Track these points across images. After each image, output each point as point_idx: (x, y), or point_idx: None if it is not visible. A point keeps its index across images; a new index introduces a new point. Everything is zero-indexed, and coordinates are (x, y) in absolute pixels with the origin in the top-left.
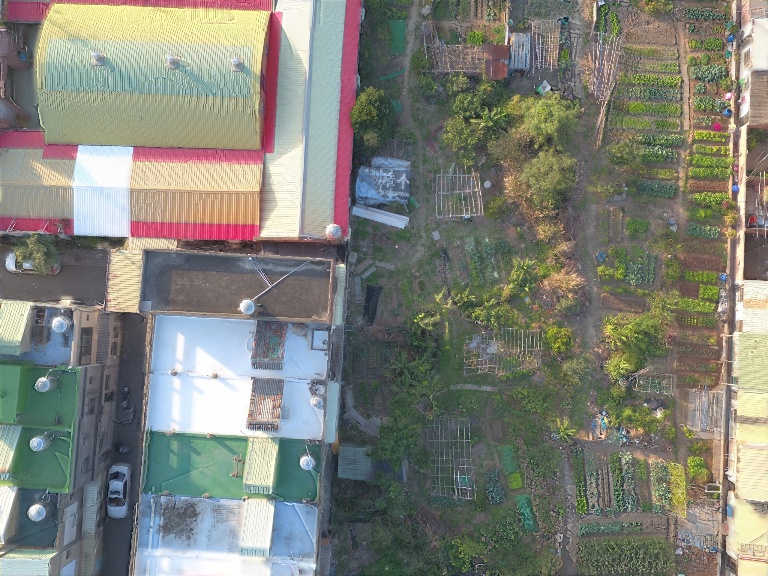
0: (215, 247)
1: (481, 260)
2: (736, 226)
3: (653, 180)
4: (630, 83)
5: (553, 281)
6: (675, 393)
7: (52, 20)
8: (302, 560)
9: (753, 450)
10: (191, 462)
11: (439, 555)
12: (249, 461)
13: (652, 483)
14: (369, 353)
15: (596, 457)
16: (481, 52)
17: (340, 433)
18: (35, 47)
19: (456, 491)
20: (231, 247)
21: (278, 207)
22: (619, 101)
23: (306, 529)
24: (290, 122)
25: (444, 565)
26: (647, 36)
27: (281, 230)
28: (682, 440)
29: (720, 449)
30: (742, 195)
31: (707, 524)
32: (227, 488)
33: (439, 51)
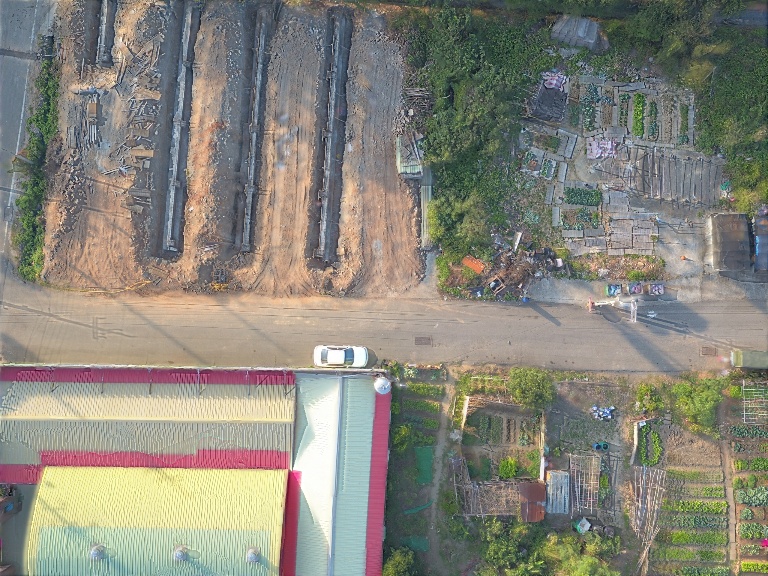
0: None
1: None
2: None
3: None
4: (673, 511)
5: None
6: None
7: (44, 498)
8: None
9: None
10: None
11: None
12: None
13: None
14: None
15: None
16: (516, 493)
17: None
18: (24, 487)
19: None
20: None
21: None
22: (662, 531)
23: None
24: None
25: None
26: (691, 457)
27: None
28: None
29: None
30: None
31: None
32: None
33: (470, 490)
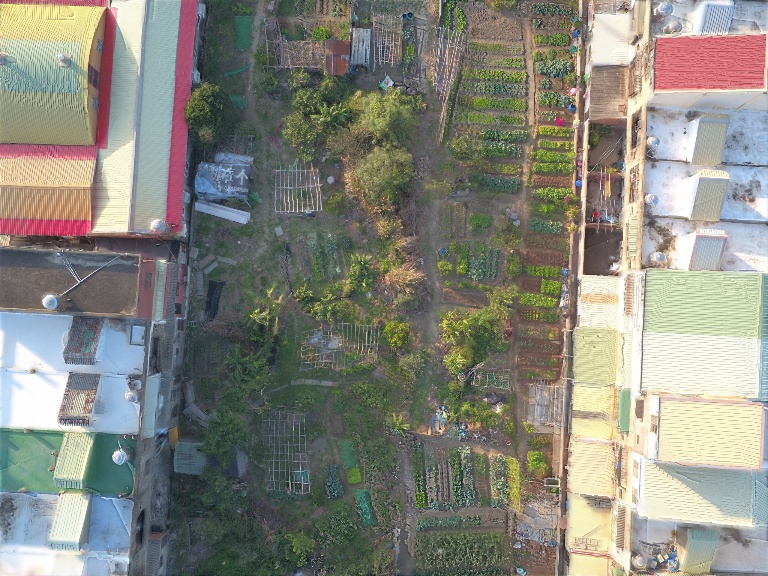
0: (51, 243)
1: (323, 255)
2: (579, 221)
3: (497, 175)
4: (475, 78)
5: (393, 276)
6: (516, 388)
7: None
8: (118, 554)
9: (587, 444)
10: (9, 457)
11: (273, 549)
12: (60, 456)
13: (491, 477)
14: (210, 348)
15: (436, 452)
16: (322, 48)
17: (180, 428)
18: None
19: (290, 486)
20: (69, 243)
21: (110, 203)
22: (464, 96)
23: (123, 524)
24: (120, 118)
25: (277, 559)
26: (493, 31)
27: (112, 226)
28: (522, 435)
29: (560, 443)
30: (584, 190)
31: (546, 518)
32: (45, 483)
33: (281, 47)
